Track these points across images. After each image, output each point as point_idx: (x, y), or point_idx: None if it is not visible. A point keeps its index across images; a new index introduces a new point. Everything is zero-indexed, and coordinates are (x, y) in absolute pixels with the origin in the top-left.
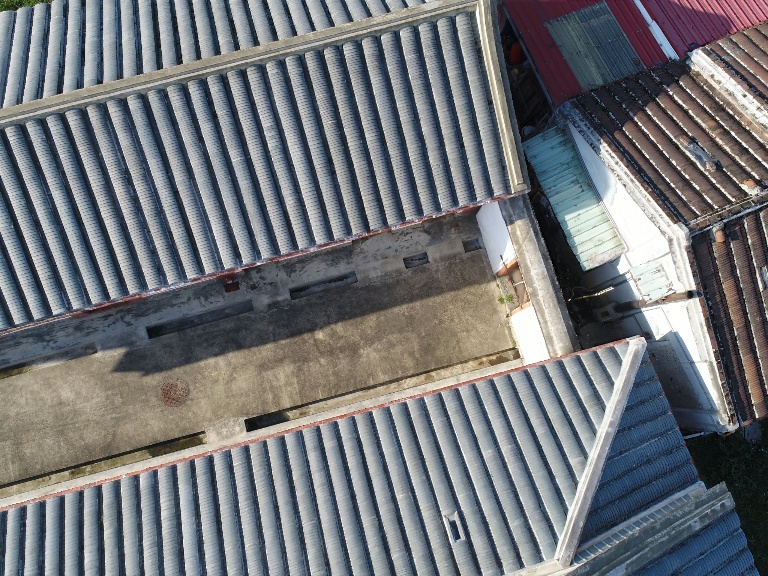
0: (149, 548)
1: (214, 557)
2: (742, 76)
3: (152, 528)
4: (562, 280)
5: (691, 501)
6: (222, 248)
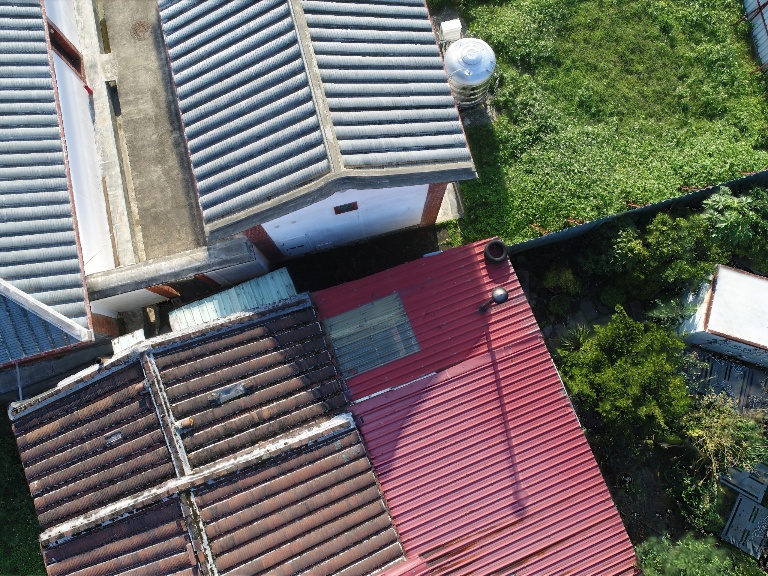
0: None
1: None
2: (312, 450)
3: None
4: None
5: None
6: (173, 7)
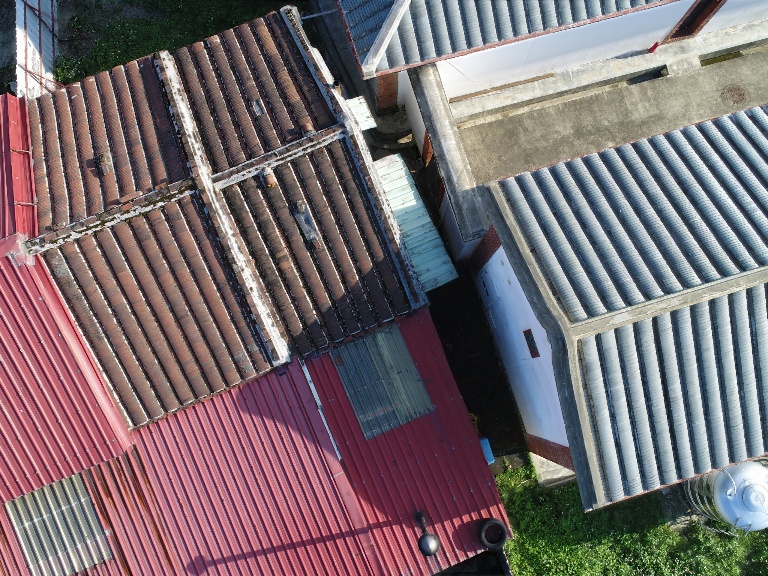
0: None
1: None
2: (246, 319)
3: None
4: None
5: None
6: None
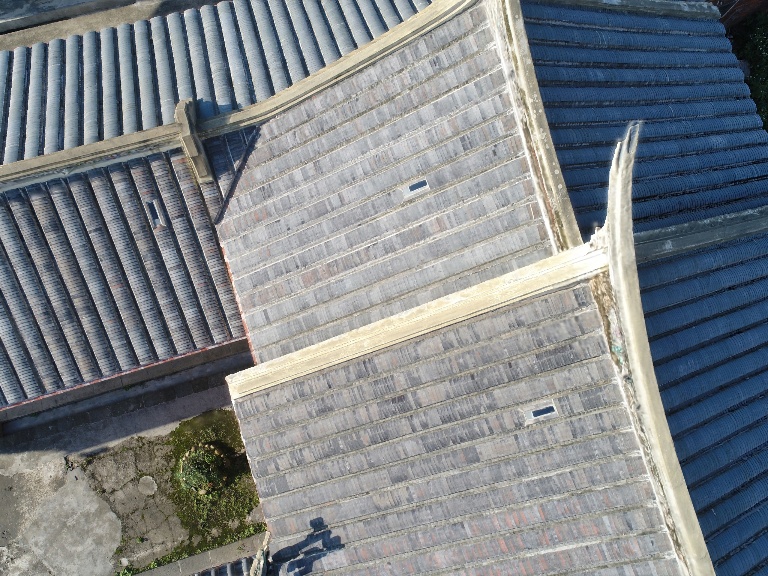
0: (195, 47)
1: (253, 47)
2: None
3: (197, 36)
4: None
5: (681, 1)
6: None
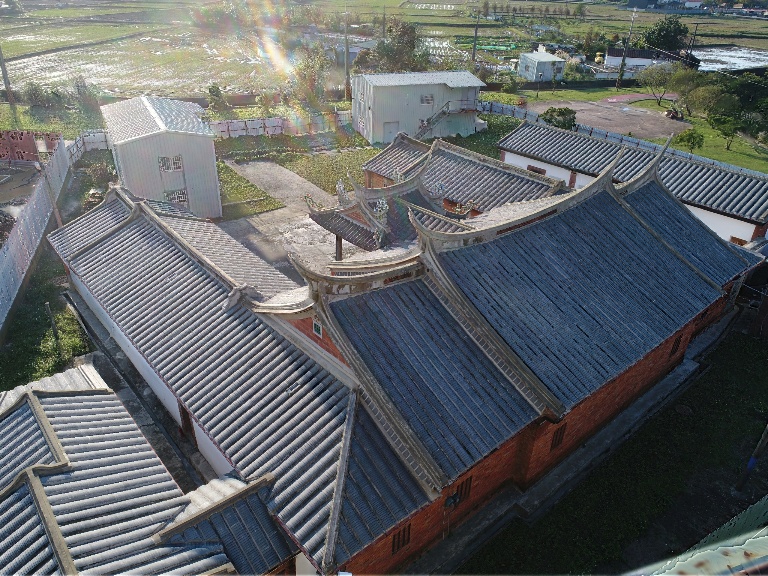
0: None
1: None
2: None
3: None
4: (759, 300)
5: None
6: None
